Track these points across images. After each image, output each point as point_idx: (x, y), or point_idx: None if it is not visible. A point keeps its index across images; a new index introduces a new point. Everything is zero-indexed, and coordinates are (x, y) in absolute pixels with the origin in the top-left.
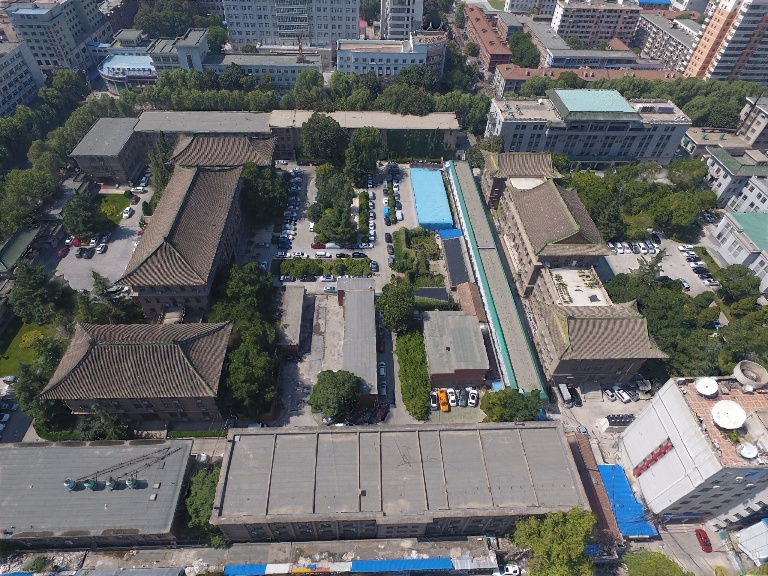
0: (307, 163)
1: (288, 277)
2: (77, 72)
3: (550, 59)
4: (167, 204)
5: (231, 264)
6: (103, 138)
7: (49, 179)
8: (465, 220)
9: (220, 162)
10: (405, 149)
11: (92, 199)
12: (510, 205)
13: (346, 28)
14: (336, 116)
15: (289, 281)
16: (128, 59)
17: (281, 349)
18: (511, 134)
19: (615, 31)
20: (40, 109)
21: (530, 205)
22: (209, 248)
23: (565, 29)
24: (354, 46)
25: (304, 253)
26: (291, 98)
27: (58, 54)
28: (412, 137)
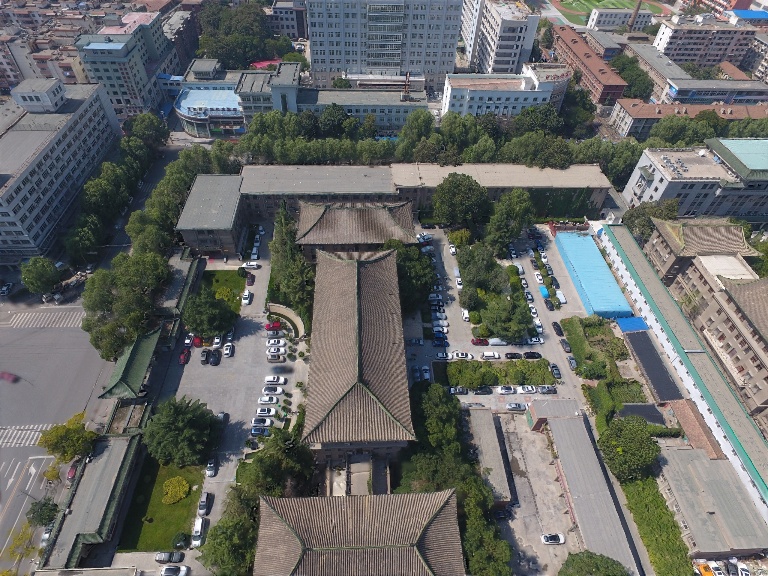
0: (433, 225)
1: (460, 390)
2: (149, 110)
3: (673, 91)
4: (327, 311)
5: (419, 394)
6: (208, 204)
7: (161, 264)
8: (653, 310)
9: (358, 239)
10: (545, 208)
11: (200, 278)
12: (717, 297)
13: (441, 55)
14: (466, 171)
15: (461, 394)
16: (206, 95)
17: (491, 506)
18: (675, 194)
19: (725, 53)
20: (124, 163)
21: (759, 305)
22: (399, 380)
23: (671, 52)
24: (465, 81)
25: (467, 353)
26: (408, 147)
27: (131, 92)
28: (555, 195)
